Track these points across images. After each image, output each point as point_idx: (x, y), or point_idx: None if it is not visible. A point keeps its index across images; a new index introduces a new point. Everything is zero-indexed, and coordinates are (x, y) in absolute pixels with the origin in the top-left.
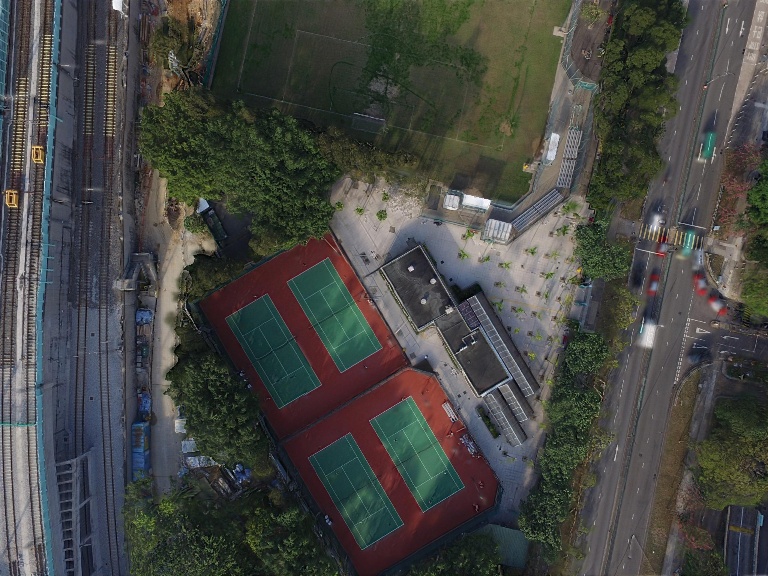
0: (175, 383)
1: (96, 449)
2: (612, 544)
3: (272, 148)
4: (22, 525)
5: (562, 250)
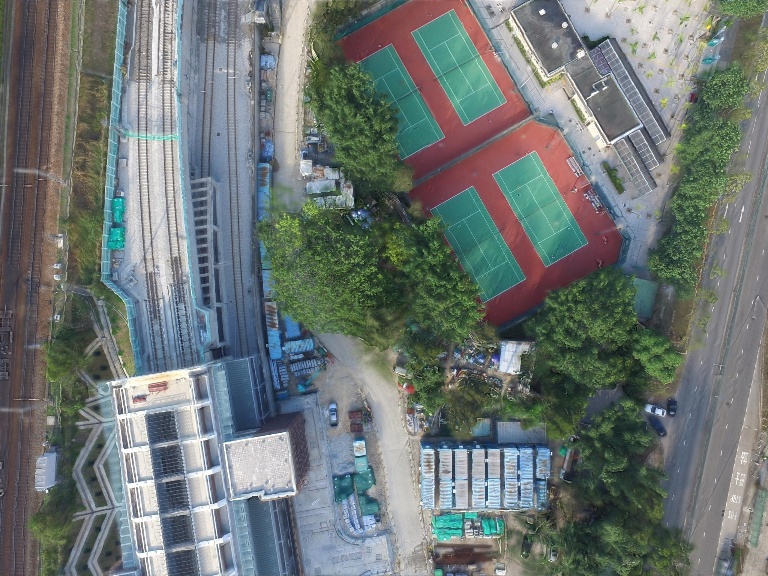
0: (317, 92)
1: (222, 185)
2: (736, 304)
3: None
4: (158, 237)
5: (691, 7)
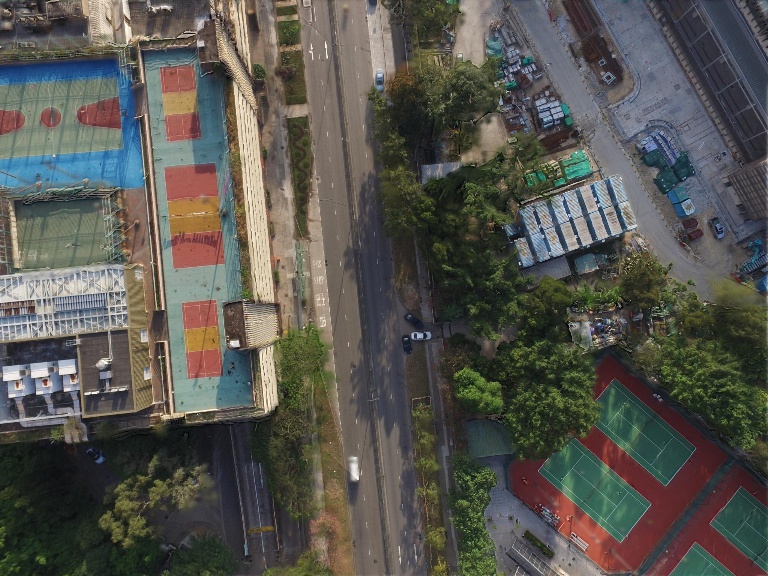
0: None
1: None
2: (377, 465)
3: None
4: None
5: None
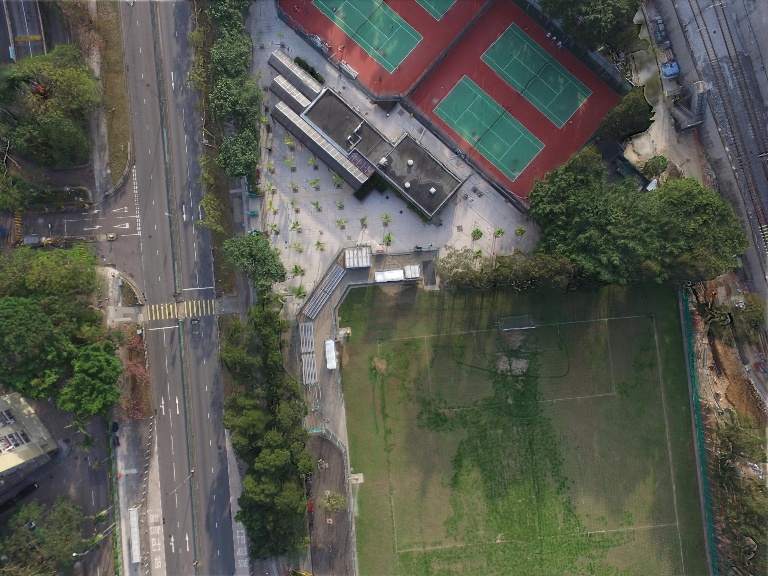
0: None
1: None
2: None
3: (616, 246)
4: None
5: (287, 261)
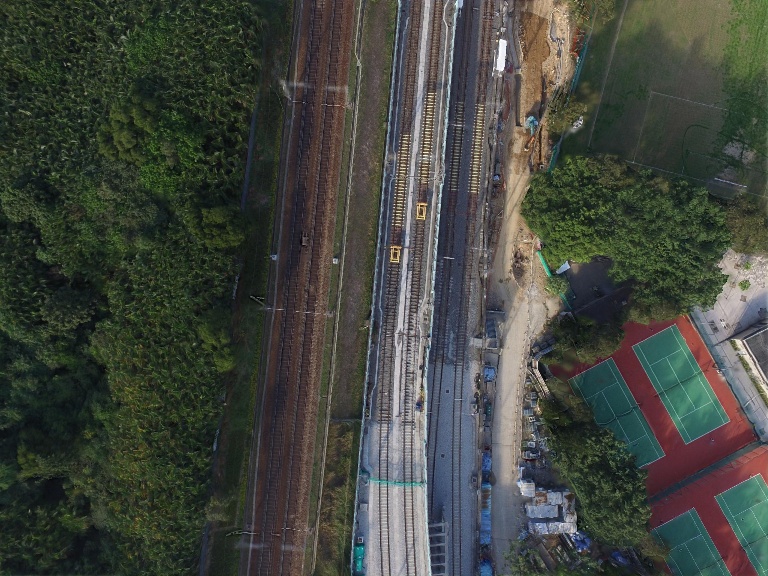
0: (566, 453)
1: (445, 508)
2: None
3: (682, 219)
4: None
5: None
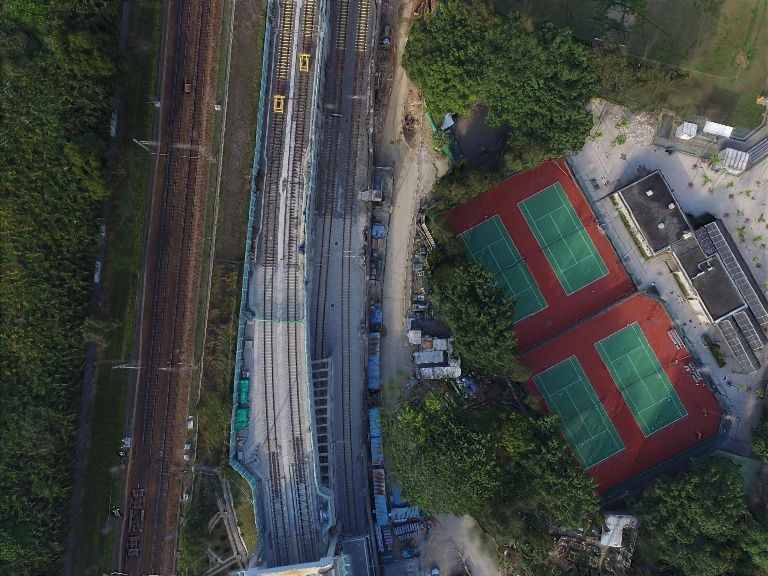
0: (439, 286)
1: (335, 355)
2: None
3: (547, 59)
4: (281, 417)
5: None
